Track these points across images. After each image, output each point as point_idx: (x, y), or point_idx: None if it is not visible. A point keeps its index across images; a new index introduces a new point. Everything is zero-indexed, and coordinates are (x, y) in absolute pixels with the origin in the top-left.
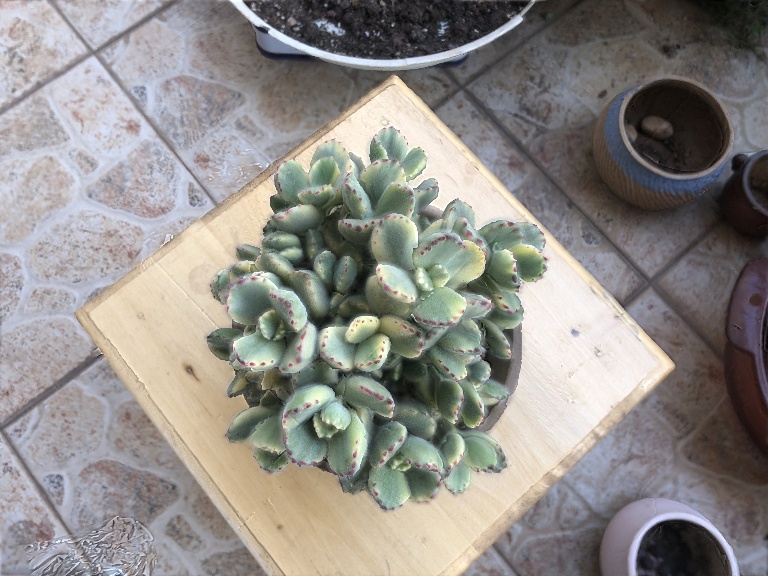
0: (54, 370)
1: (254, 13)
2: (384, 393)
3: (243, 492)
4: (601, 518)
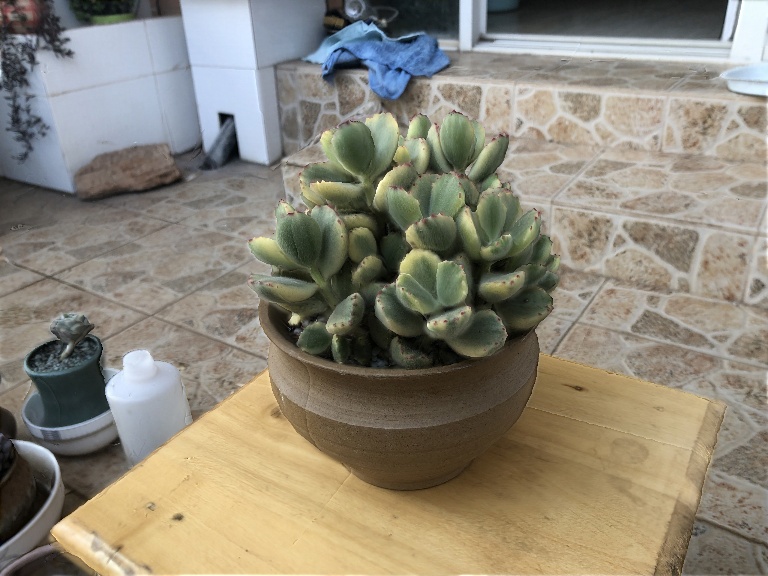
0: None
1: None
2: None
3: None
4: None
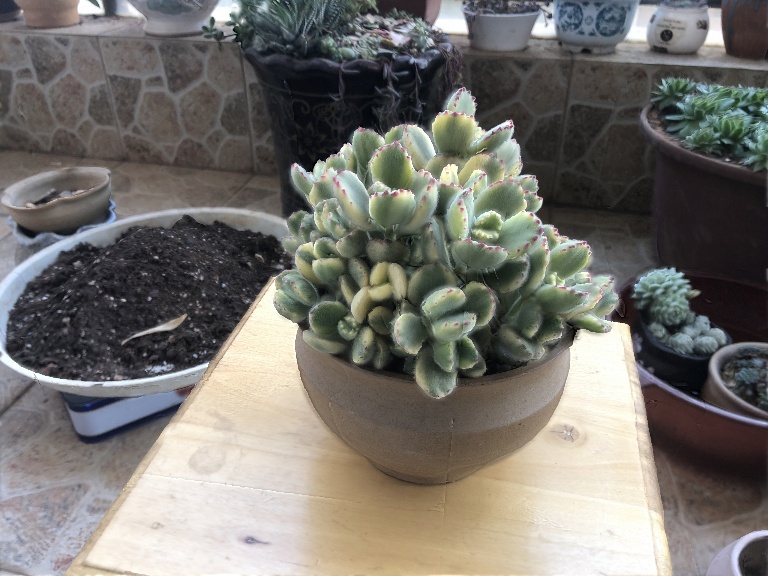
0: None
1: (80, 380)
2: None
3: None
4: None
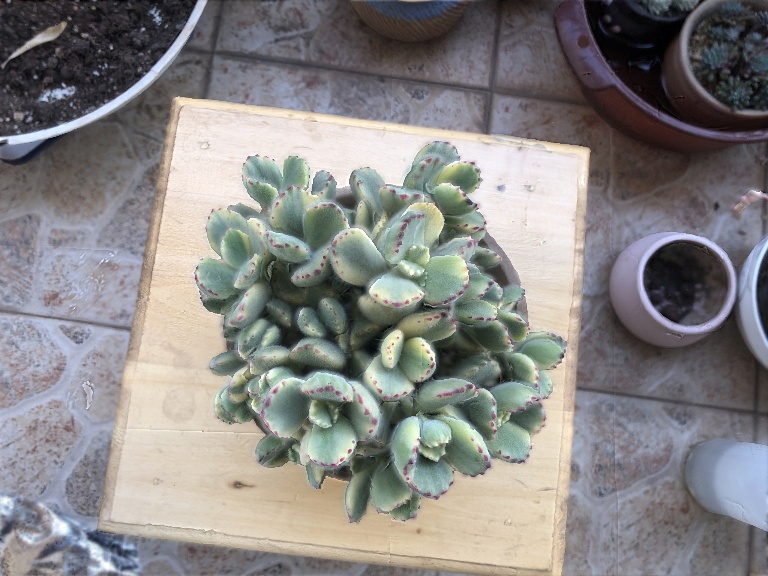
0: (96, 574)
1: None
2: (460, 384)
3: (368, 534)
4: (600, 296)
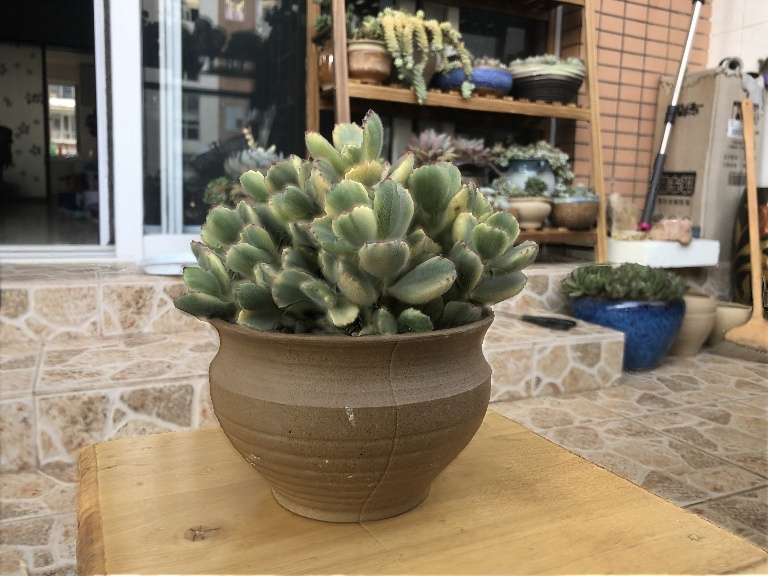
0: None
1: None
2: (281, 164)
3: None
4: None
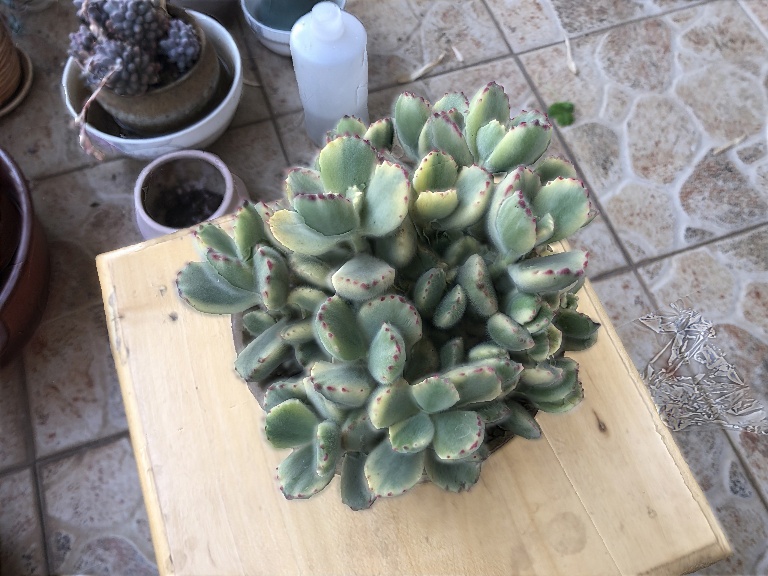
0: None
1: None
2: (440, 123)
3: None
4: None
